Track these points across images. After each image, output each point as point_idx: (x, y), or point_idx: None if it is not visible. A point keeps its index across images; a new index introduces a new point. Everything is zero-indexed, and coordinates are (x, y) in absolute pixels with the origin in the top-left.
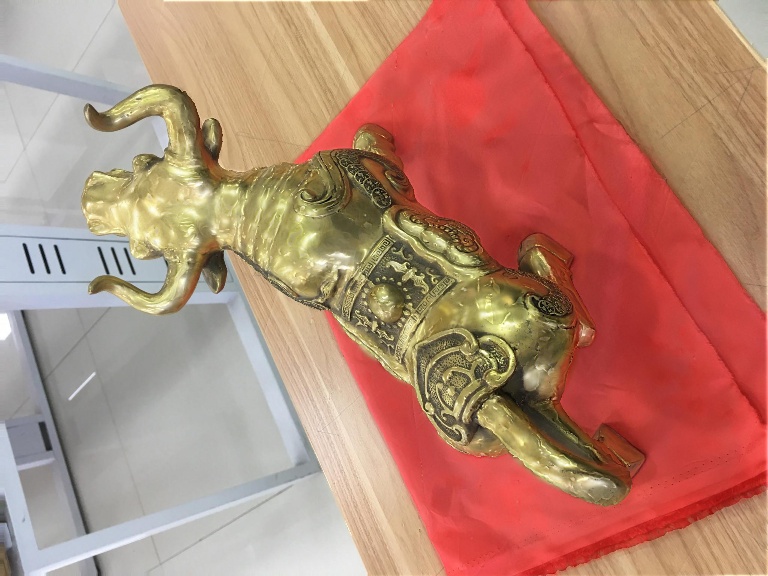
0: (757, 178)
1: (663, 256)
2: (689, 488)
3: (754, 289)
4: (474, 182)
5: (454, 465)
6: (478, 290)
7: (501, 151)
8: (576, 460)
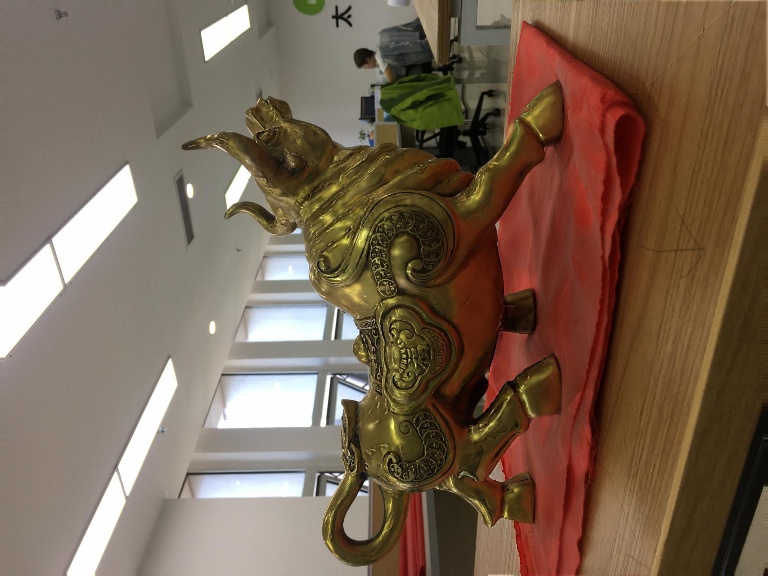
0: None
1: (574, 503)
2: None
3: None
4: (563, 268)
5: (511, 369)
6: (386, 413)
7: None
8: (333, 539)
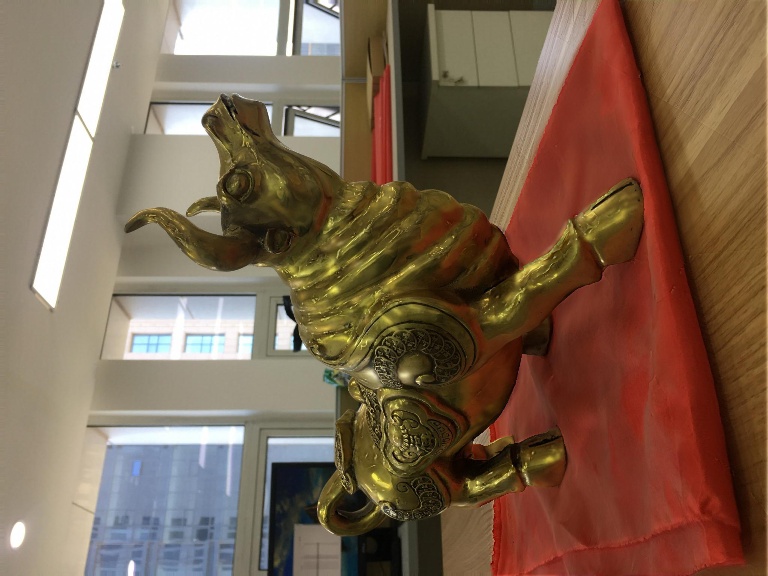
0: None
1: (557, 570)
2: None
3: None
4: (593, 392)
5: None
6: None
7: None
8: None
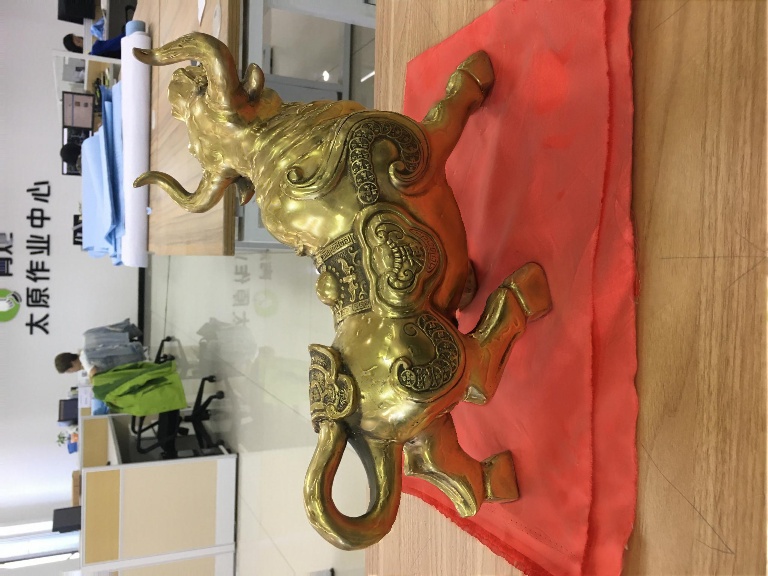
0: (703, 365)
1: (605, 366)
2: (530, 543)
3: (644, 454)
4: (524, 177)
5: None
6: (380, 327)
7: (553, 163)
8: (325, 510)
